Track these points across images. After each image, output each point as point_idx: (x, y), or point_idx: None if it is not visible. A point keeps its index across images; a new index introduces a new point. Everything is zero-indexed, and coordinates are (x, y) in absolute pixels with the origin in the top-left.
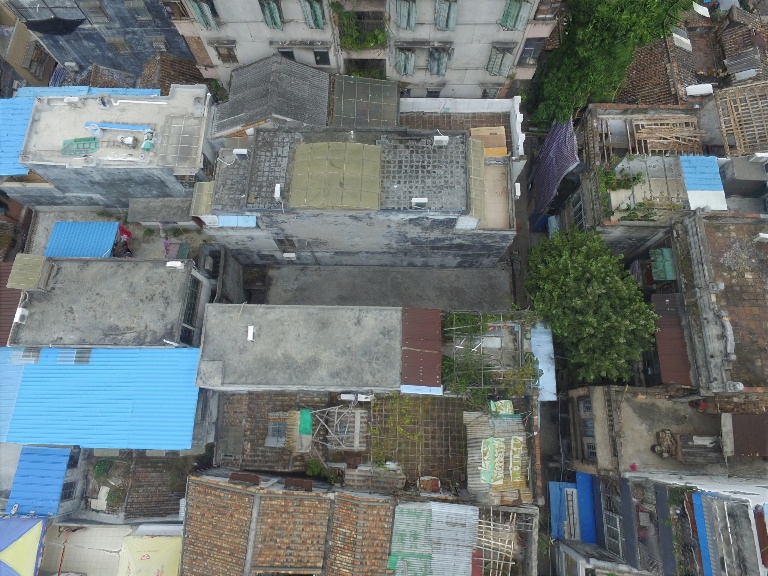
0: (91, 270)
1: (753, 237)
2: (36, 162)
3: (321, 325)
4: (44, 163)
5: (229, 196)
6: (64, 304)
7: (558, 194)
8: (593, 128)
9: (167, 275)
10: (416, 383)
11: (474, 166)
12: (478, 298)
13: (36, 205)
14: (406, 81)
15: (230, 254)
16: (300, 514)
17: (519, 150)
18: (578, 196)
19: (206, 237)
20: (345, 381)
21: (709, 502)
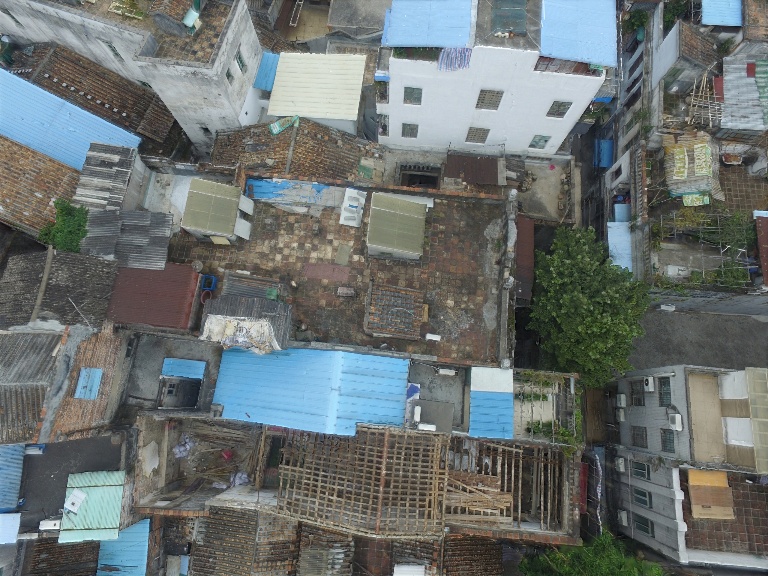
0: None
1: None
2: None
3: None
4: None
5: None
6: None
7: None
8: None
9: None
10: None
11: (767, 438)
12: (641, 340)
13: None
14: None
15: None
16: None
17: None
18: None
19: None
20: None
21: None
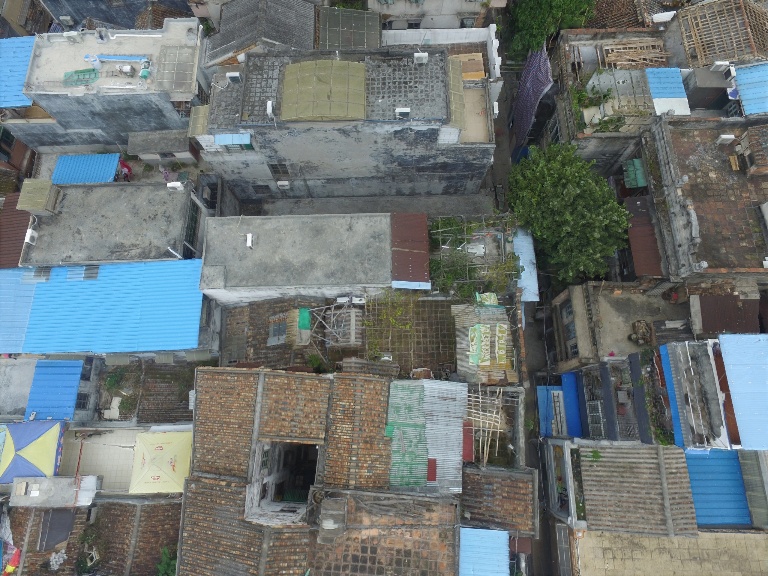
0: (95, 195)
1: (716, 140)
2: (39, 92)
3: (315, 232)
4: (47, 93)
5: (224, 116)
6: (71, 226)
7: (536, 121)
8: (565, 51)
9: (168, 196)
10: (406, 279)
11: (453, 83)
12: None
13: (39, 146)
14: (387, 13)
15: (226, 186)
16: (302, 392)
17: (496, 73)
18: (554, 121)
19: (203, 170)
20: (340, 280)
21: (674, 348)
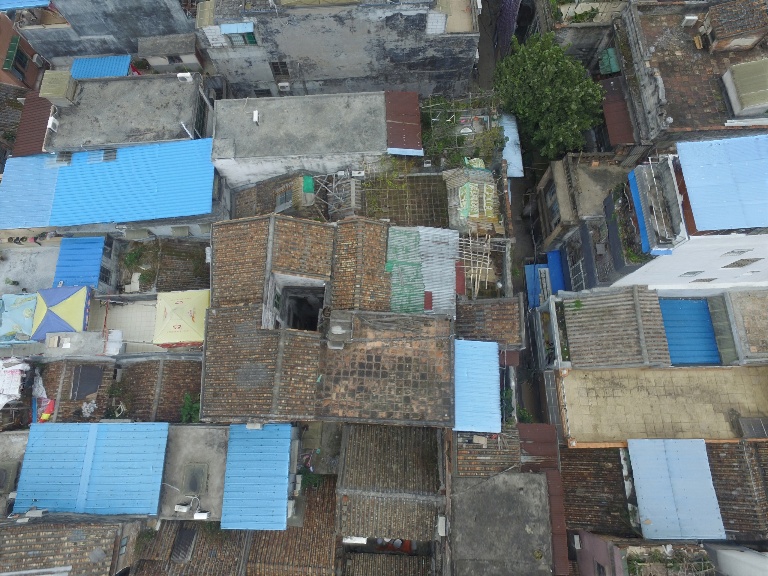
0: (111, 88)
1: (681, 23)
2: None
3: (316, 110)
4: None
5: (228, 8)
6: (89, 115)
7: (518, 26)
8: None
9: (178, 87)
10: (400, 147)
11: None
12: None
13: (53, 56)
14: None
15: (231, 90)
16: (309, 236)
17: None
18: (535, 24)
19: None
20: (340, 149)
21: (639, 169)
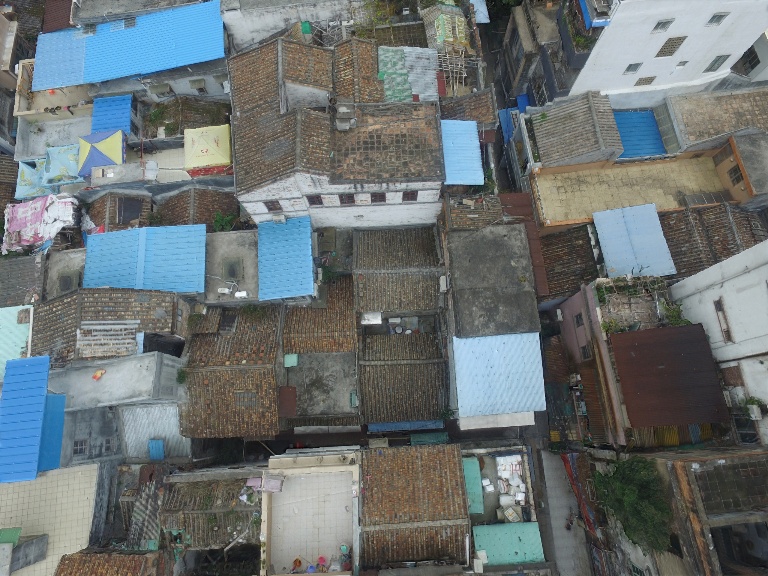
0: None
1: None
2: None
3: None
4: None
5: None
6: None
7: None
8: None
9: None
10: None
11: None
12: None
13: None
14: None
15: None
16: (311, 56)
17: None
18: None
19: None
20: None
21: None
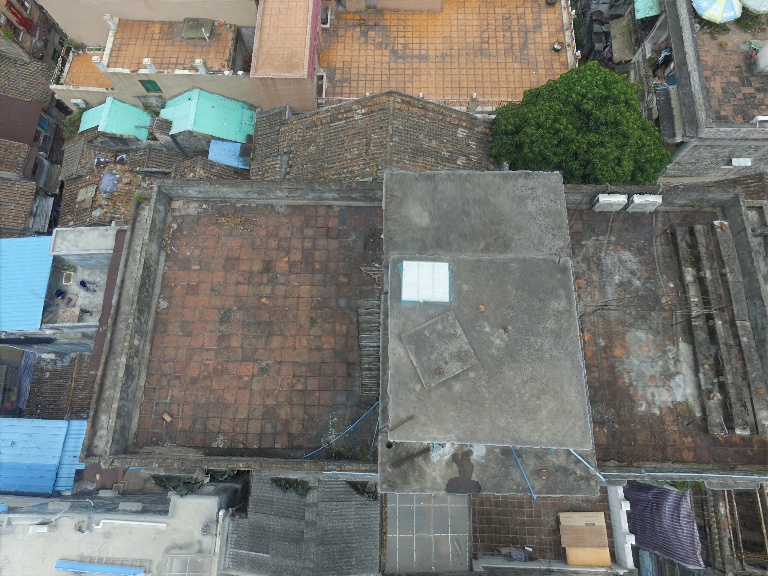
0: None
1: None
2: None
3: None
4: None
5: None
6: None
7: (662, 558)
8: (720, 516)
9: None
10: None
11: None
12: None
13: None
14: None
15: None
16: None
17: (627, 558)
18: (690, 570)
19: None
20: None
21: None
